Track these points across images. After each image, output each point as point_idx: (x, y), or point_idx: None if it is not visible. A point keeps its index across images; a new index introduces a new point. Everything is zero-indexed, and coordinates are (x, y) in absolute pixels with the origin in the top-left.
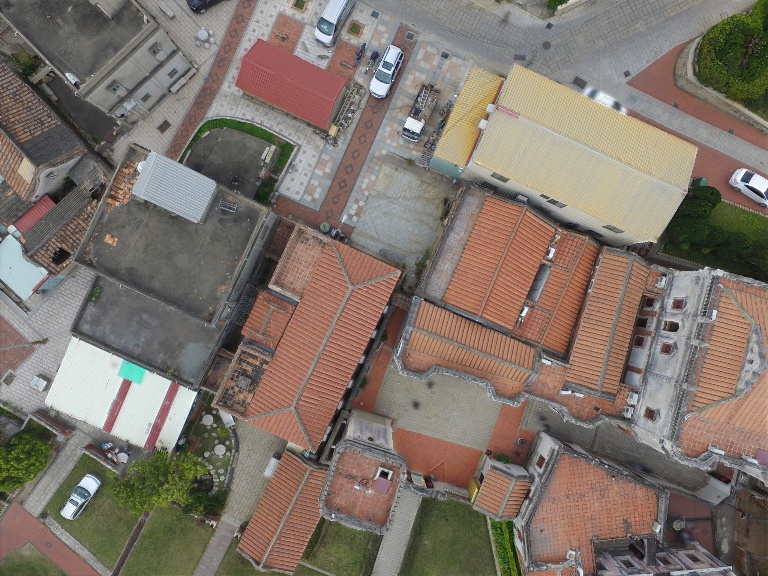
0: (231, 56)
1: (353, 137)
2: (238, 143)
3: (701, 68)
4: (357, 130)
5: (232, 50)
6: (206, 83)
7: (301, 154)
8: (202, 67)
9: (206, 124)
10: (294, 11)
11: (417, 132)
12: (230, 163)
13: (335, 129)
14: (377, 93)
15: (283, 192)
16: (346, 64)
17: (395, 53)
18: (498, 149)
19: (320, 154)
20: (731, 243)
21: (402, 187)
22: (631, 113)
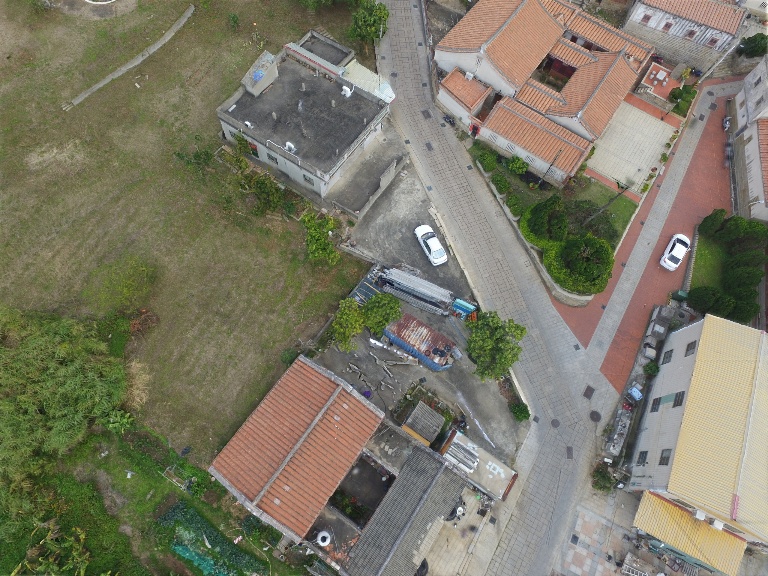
0: None
1: None
2: None
3: None
4: None
5: None
6: None
7: None
8: None
9: None
10: None
11: None
12: None
13: None
14: None
15: None
16: None
17: None
18: (764, 517)
19: None
20: (752, 283)
21: None
22: (613, 347)
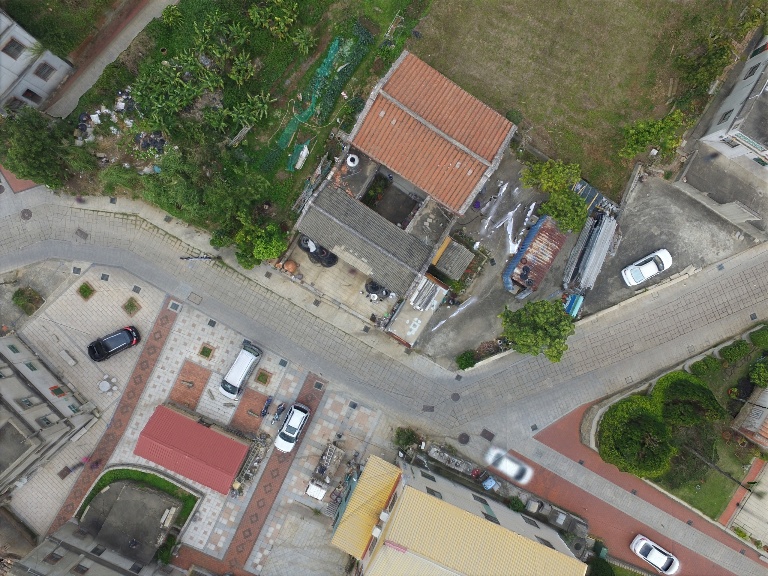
0: (135, 402)
1: (258, 486)
2: (137, 503)
3: (601, 450)
4: (263, 479)
5: (136, 396)
6: (109, 429)
7: (205, 503)
8: (105, 413)
9: (107, 474)
10: (200, 358)
11: (319, 499)
12: (128, 525)
13: (239, 484)
14: (282, 449)
15: (186, 541)
16: (252, 414)
17: (299, 418)
18: (386, 575)
19: (224, 502)
20: None
21: (307, 536)
22: (537, 467)
